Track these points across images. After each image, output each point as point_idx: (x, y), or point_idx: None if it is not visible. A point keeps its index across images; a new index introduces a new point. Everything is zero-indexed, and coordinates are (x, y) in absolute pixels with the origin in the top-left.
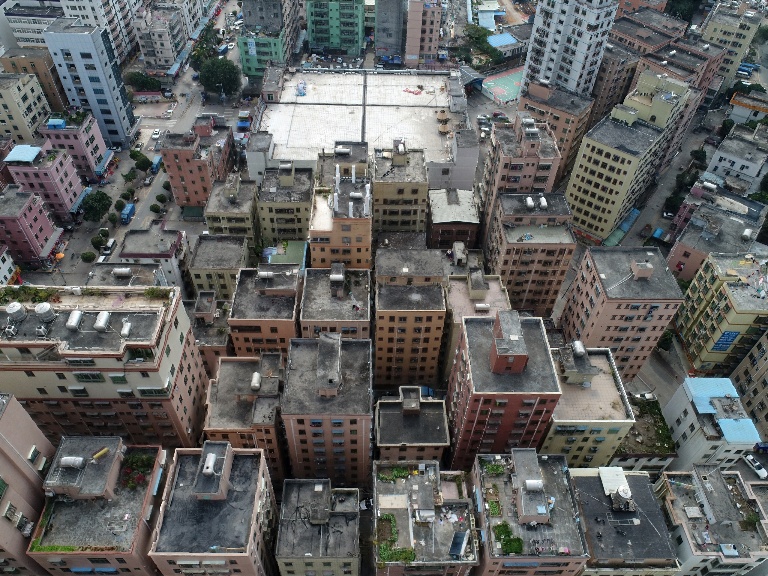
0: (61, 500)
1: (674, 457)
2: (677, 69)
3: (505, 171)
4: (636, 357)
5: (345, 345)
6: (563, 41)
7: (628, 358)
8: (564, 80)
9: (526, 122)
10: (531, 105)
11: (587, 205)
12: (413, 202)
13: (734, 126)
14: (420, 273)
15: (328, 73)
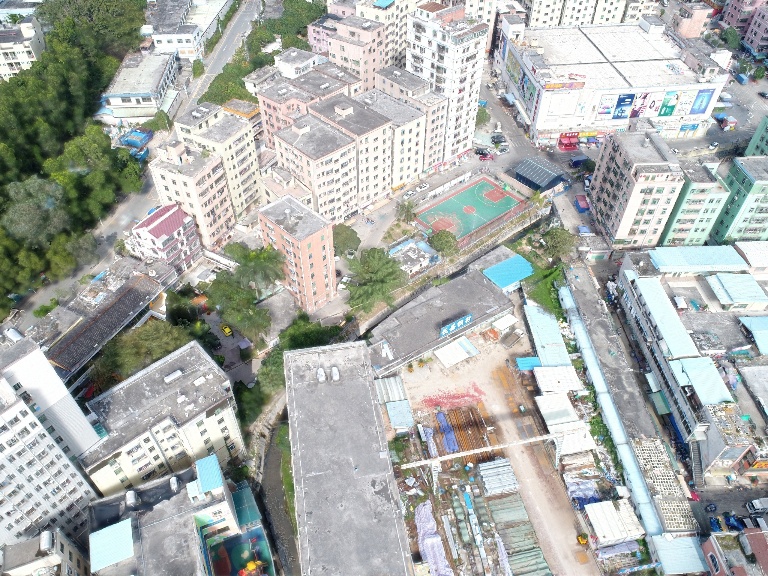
0: None
1: None
2: None
3: None
4: None
5: None
6: None
7: None
8: None
9: None
10: None
11: None
12: None
13: None
14: None
15: None
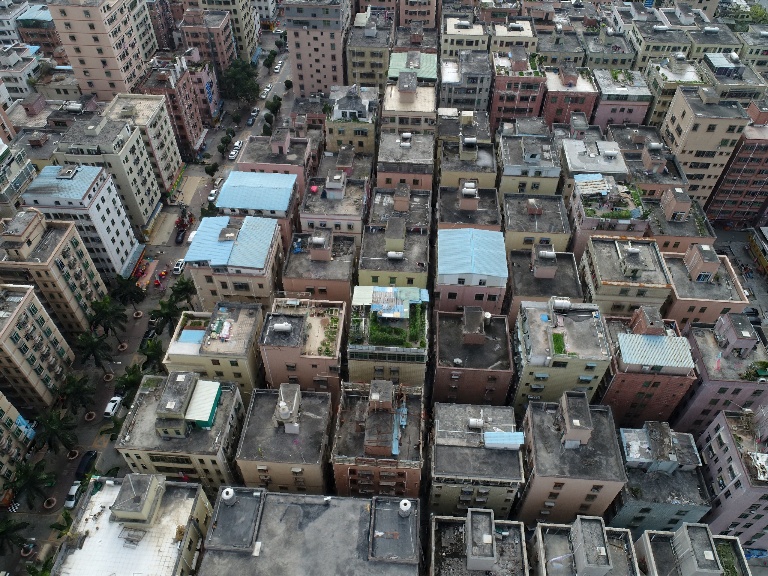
0: None
1: None
2: None
3: None
4: None
5: None
6: None
7: None
8: None
9: None
10: None
11: None
12: None
13: None
14: None
15: None
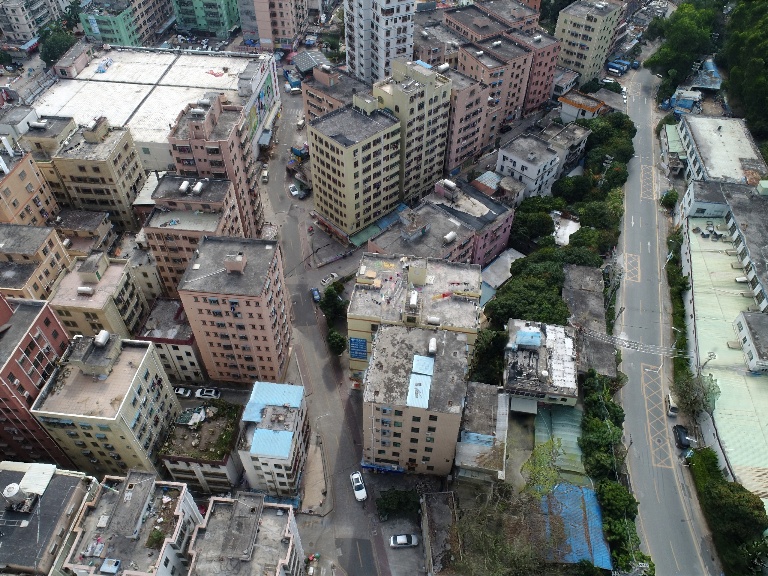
0: None
1: (221, 465)
2: (492, 60)
3: (177, 153)
4: (260, 357)
5: None
6: (368, 26)
7: (251, 358)
8: (376, 68)
9: (200, 102)
10: (310, 91)
11: (329, 198)
12: (101, 181)
13: (548, 125)
14: (12, 250)
15: (143, 52)
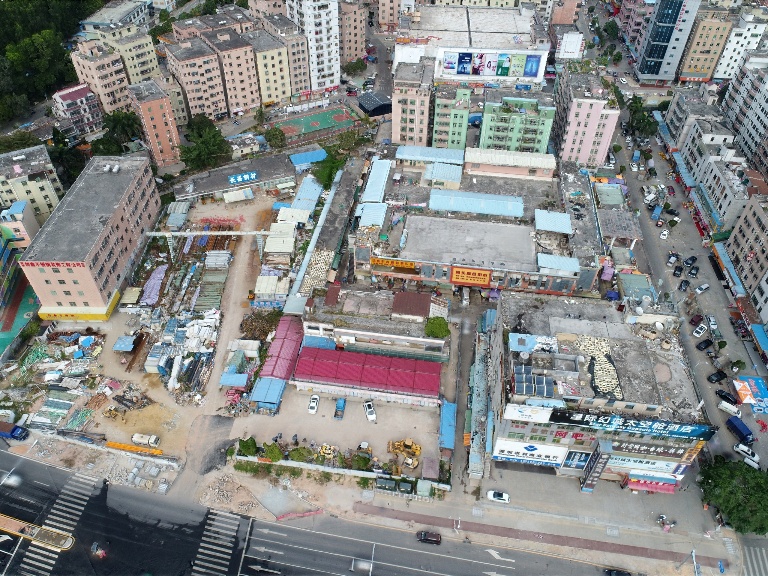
0: None
1: None
2: None
3: None
4: None
5: None
6: None
7: None
8: None
9: None
10: None
11: None
12: None
13: None
14: None
15: None
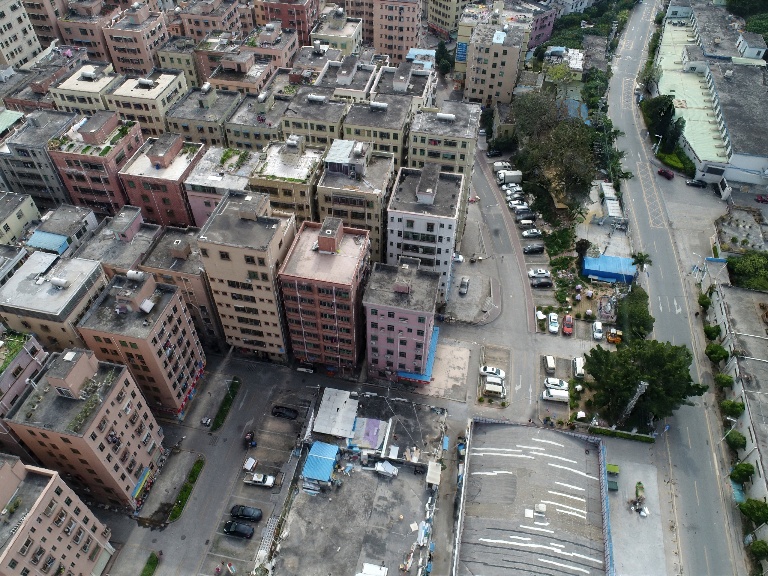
0: (74, 11)
1: None
2: None
3: None
4: None
5: (225, 2)
6: None
7: (402, 56)
8: None
9: None
10: None
11: (439, 6)
12: None
13: None
14: None
15: None
